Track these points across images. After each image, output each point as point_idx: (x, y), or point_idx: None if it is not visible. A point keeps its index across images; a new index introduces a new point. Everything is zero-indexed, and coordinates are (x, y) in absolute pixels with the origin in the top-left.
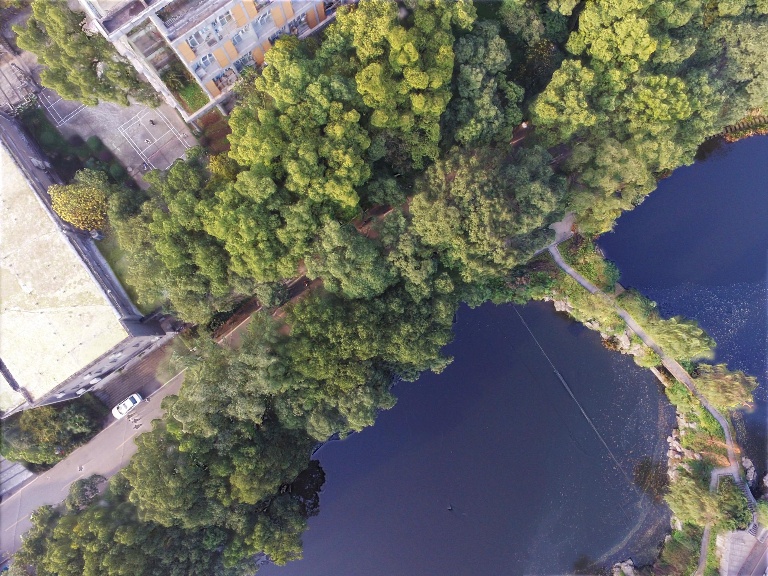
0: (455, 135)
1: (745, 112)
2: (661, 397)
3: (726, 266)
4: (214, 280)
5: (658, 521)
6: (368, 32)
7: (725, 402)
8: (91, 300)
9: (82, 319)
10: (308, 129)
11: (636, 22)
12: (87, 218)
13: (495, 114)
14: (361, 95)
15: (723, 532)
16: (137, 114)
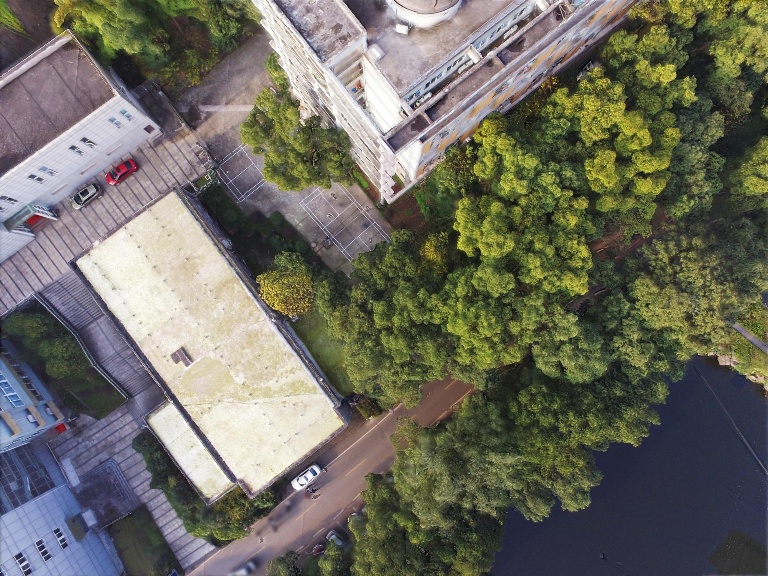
0: (665, 211)
1: None
2: None
3: None
4: (434, 369)
5: None
6: (598, 117)
7: None
8: (304, 389)
9: (296, 409)
10: (537, 218)
11: None
12: (298, 307)
13: None
14: (587, 180)
15: None
16: (318, 188)
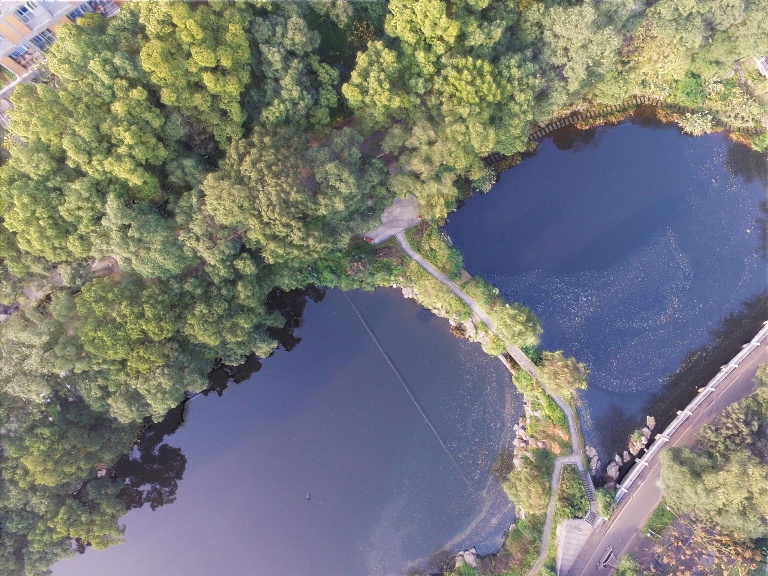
0: (260, 115)
1: (563, 96)
2: (508, 385)
3: (575, 254)
4: (6, 258)
5: (503, 510)
6: (153, 9)
7: (556, 389)
8: None
9: None
10: (93, 106)
11: (429, 2)
12: None
13: (300, 95)
14: (149, 73)
15: (560, 520)
16: None
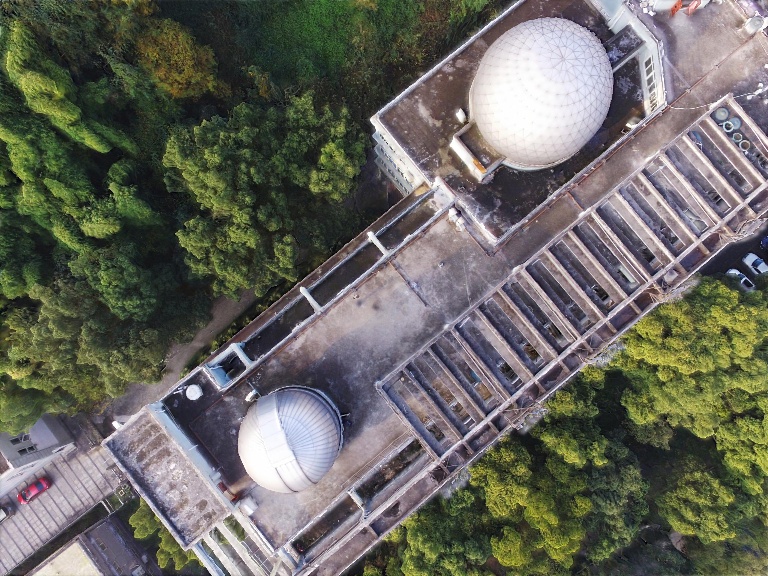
0: (585, 554)
1: None
2: None
3: None
4: None
5: None
6: (502, 495)
7: None
8: None
9: None
10: None
11: None
12: None
13: None
14: None
15: None
16: None
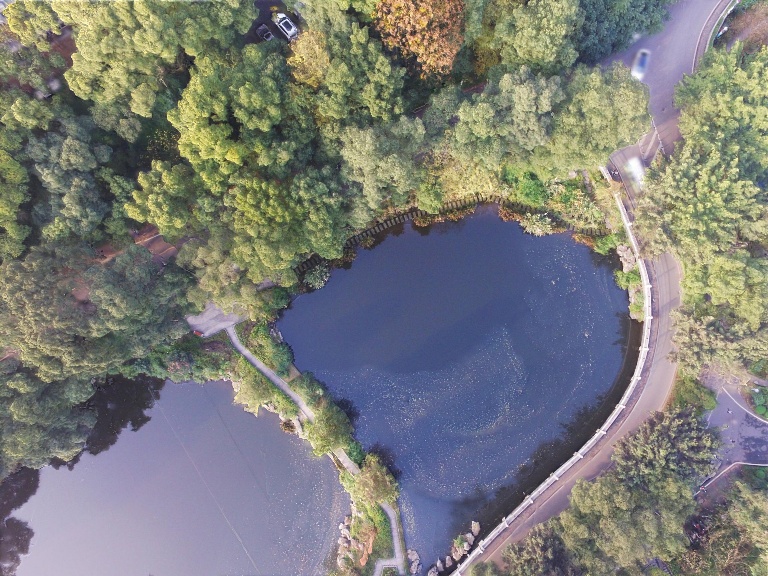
0: None
1: (364, 214)
2: (336, 483)
3: (407, 354)
4: None
5: None
6: None
7: (365, 500)
8: None
9: None
10: None
11: (199, 131)
12: None
13: (83, 212)
14: None
15: None
16: None
